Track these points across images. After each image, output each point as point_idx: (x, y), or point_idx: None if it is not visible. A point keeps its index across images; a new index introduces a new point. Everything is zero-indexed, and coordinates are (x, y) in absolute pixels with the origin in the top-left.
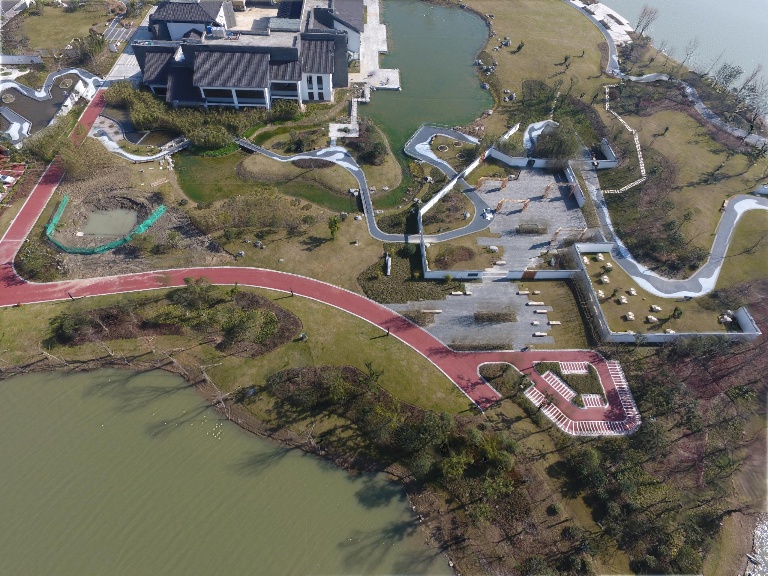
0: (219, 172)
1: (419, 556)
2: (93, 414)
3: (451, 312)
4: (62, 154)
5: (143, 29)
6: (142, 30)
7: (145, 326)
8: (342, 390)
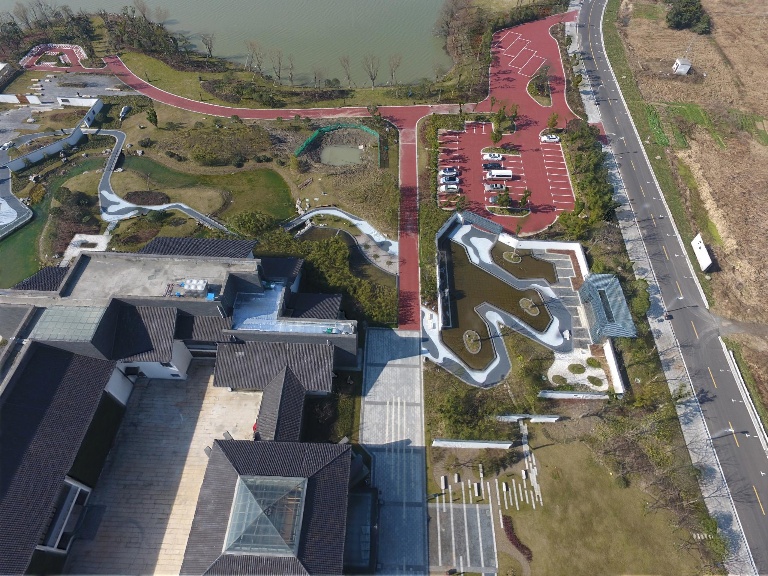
0: (250, 198)
1: (177, 34)
2: (319, 72)
3: (100, 89)
4: (391, 180)
5: (415, 569)
6: (416, 563)
7: (298, 94)
8: (183, 39)
